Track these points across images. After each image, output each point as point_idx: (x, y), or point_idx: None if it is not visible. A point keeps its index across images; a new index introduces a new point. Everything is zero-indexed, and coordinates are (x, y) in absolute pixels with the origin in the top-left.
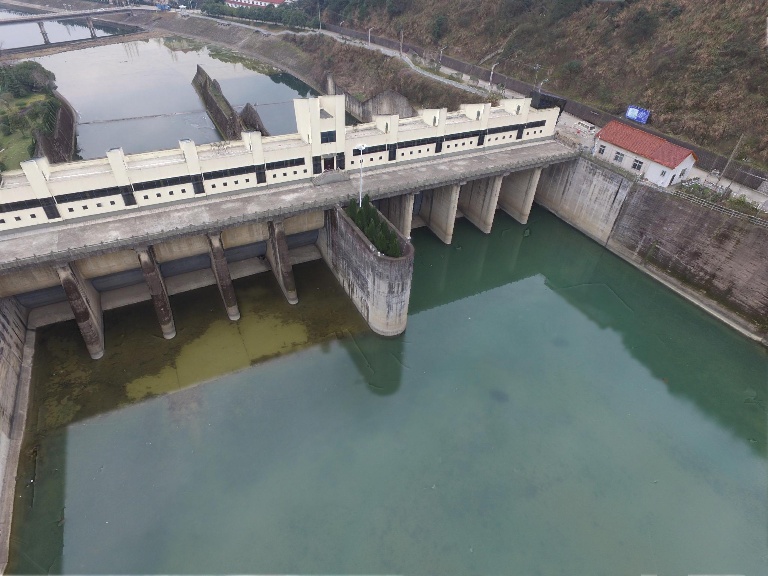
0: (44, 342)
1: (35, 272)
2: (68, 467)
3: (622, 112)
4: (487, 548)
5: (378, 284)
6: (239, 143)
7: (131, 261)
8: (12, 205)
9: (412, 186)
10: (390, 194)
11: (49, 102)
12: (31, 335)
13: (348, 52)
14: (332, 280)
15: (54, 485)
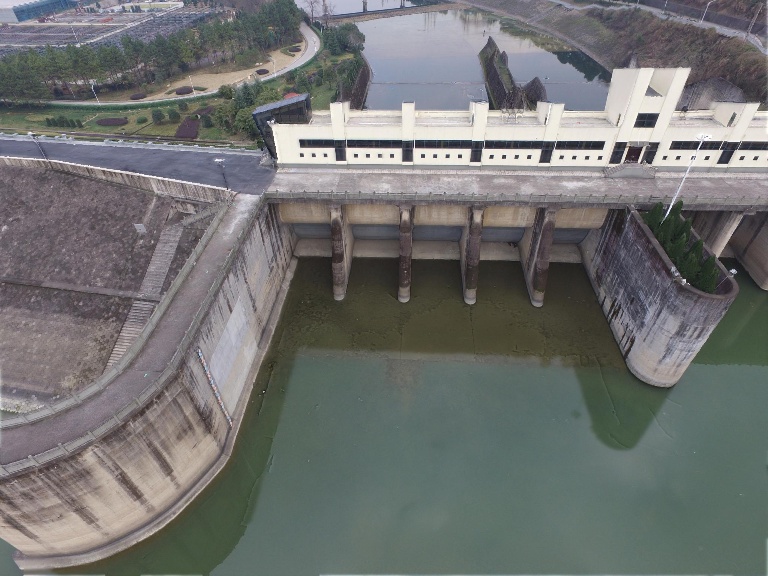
0: (302, 270)
1: (313, 207)
2: (292, 392)
3: None
4: None
5: (664, 319)
6: (532, 114)
7: (391, 217)
8: (313, 142)
9: (747, 203)
10: (710, 207)
11: (356, 60)
12: (294, 261)
13: (667, 30)
14: (588, 292)
15: (278, 403)
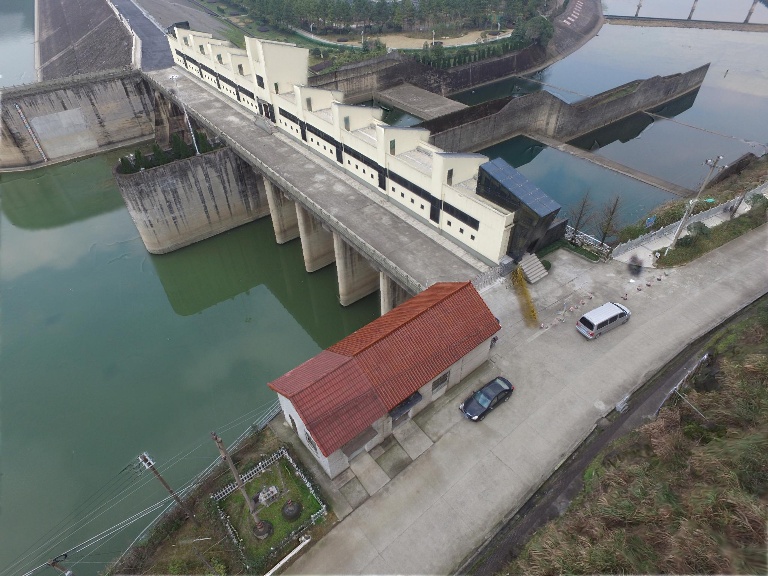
0: None
1: None
2: None
3: (712, 366)
4: None
5: None
6: None
7: None
8: None
9: None
10: (242, 156)
11: (490, 48)
12: None
13: None
14: None
15: None
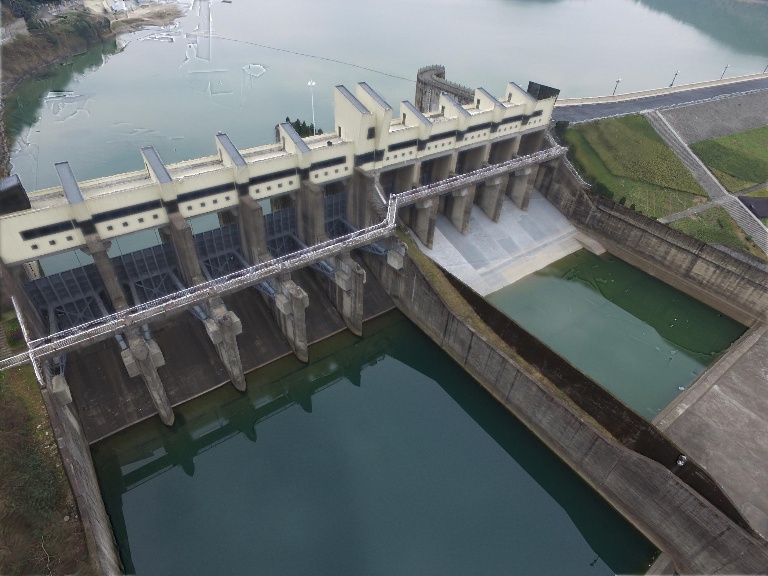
0: None
1: None
2: None
3: None
4: (258, 141)
5: None
6: None
7: None
8: None
9: None
10: None
11: None
12: None
13: None
14: None
15: None
